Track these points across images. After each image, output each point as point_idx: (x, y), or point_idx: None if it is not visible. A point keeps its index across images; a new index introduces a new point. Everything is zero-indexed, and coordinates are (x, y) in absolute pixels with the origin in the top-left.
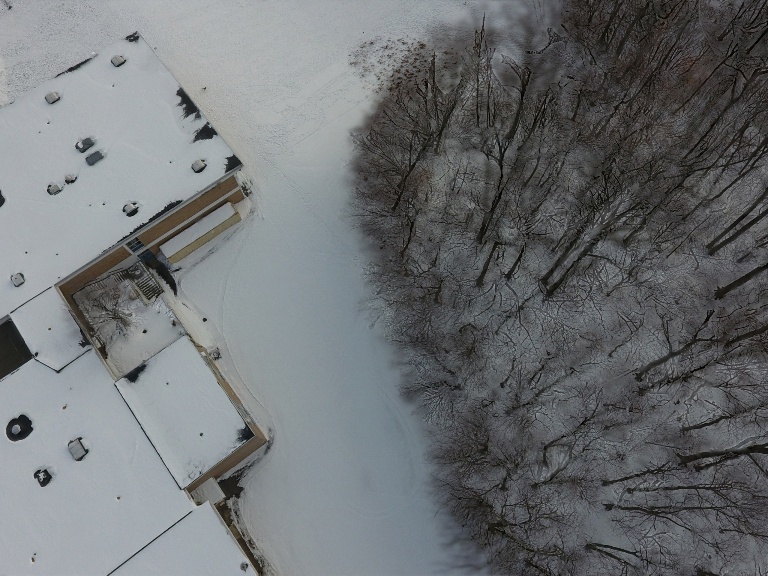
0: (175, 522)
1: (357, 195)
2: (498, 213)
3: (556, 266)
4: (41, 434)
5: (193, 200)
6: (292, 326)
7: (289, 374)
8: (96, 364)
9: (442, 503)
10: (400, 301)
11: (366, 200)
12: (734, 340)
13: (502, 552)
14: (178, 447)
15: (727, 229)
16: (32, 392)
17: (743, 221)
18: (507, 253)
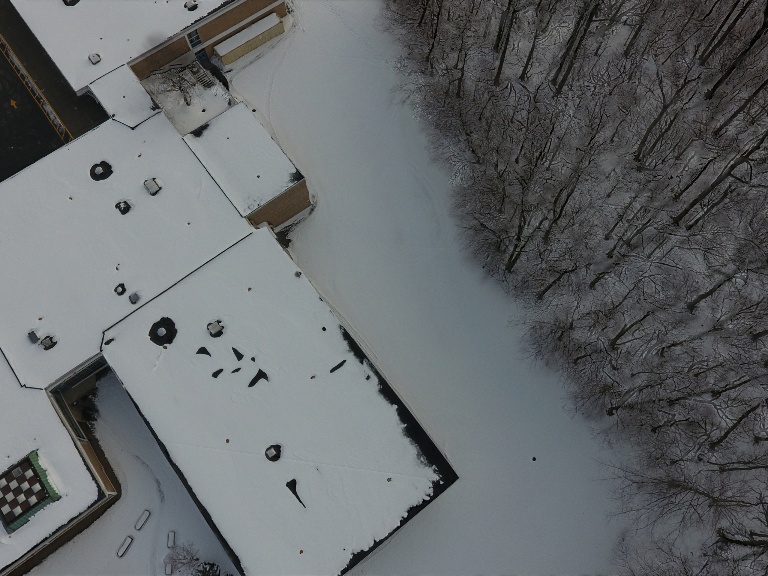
0: (238, 240)
1: (387, 12)
2: (514, 2)
3: (565, 58)
4: (120, 175)
5: (245, 1)
6: (331, 116)
7: (329, 153)
8: (165, 123)
9: (466, 244)
10: (428, 85)
11: (395, 17)
12: (721, 126)
13: (518, 286)
14: (239, 186)
15: (716, 33)
16: (111, 144)
17: (729, 19)
18: (522, 44)
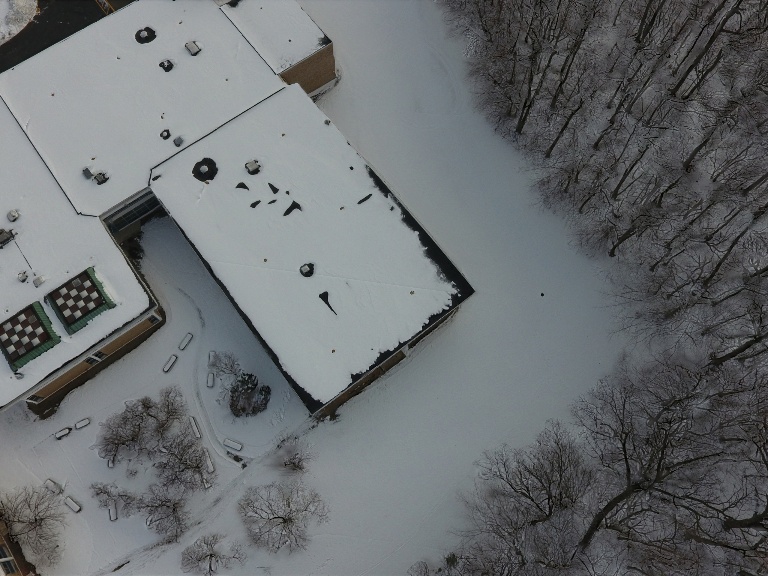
0: (272, 93)
1: None
2: None
3: None
4: (163, 39)
5: None
6: (354, 2)
7: (352, 34)
8: None
9: (479, 106)
10: None
11: None
12: (716, 10)
13: (527, 145)
14: (272, 48)
15: None
16: (154, 12)
17: None
18: None
